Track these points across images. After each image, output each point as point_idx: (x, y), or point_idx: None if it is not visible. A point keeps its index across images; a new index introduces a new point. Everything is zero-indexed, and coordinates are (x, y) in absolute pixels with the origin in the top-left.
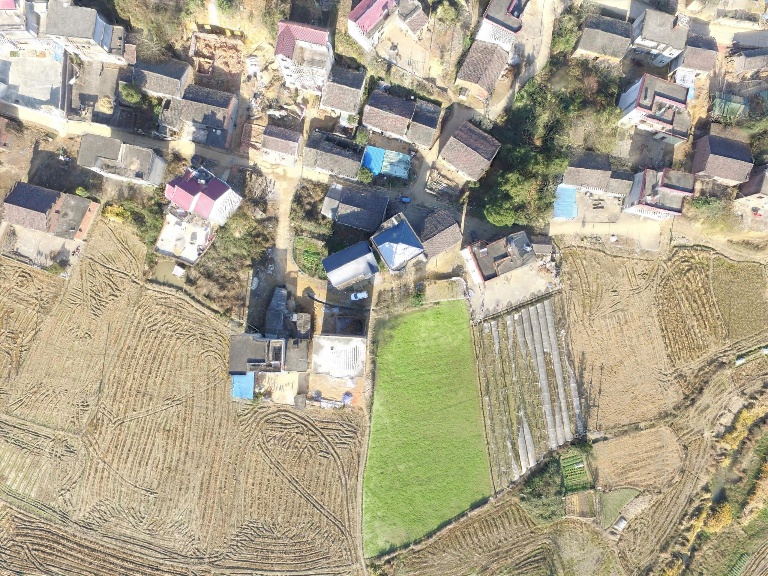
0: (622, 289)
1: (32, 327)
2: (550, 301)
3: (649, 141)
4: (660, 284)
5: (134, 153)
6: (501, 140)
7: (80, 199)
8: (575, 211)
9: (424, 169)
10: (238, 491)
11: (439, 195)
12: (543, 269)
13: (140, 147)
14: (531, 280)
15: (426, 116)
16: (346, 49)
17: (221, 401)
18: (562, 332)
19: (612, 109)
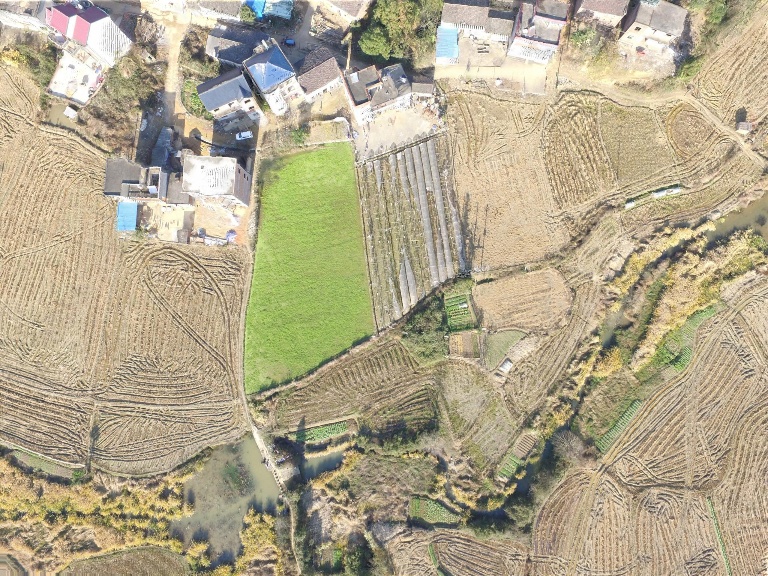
0: (508, 132)
1: None
2: (433, 141)
3: None
4: (546, 128)
5: None
6: None
7: None
8: (456, 51)
9: (309, 13)
10: (123, 326)
11: None
12: (427, 111)
13: None
14: (415, 122)
15: None
16: None
17: (108, 238)
18: (445, 171)
19: None
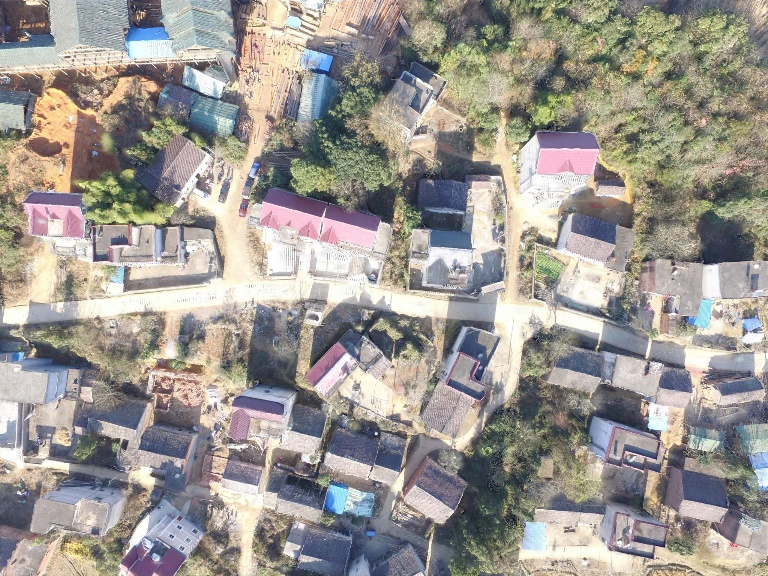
0: None
1: None
2: None
3: None
4: None
5: (90, 507)
6: (467, 477)
7: None
8: (544, 544)
9: (389, 499)
10: None
11: (404, 527)
12: None
13: (96, 502)
14: None
15: (390, 454)
16: (307, 386)
17: None
18: None
19: (583, 436)
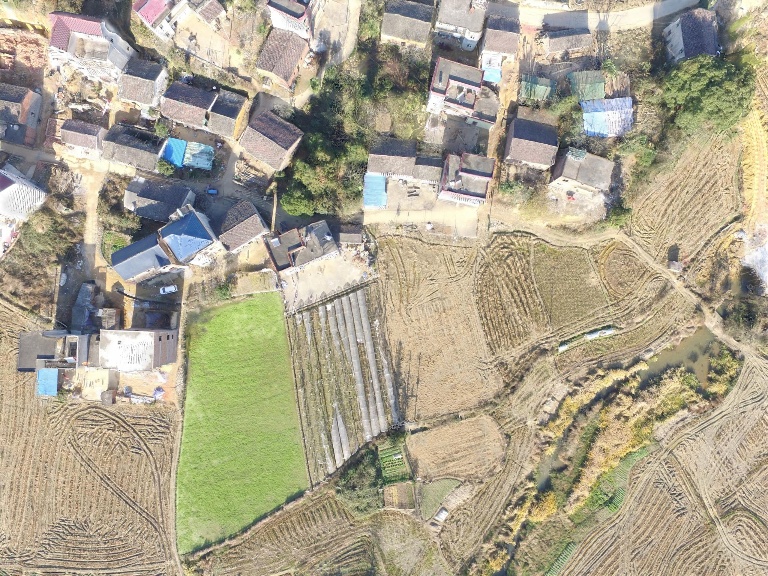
0: (440, 277)
1: None
2: (363, 291)
3: (463, 127)
4: (479, 271)
5: None
6: (305, 129)
7: None
8: (384, 199)
9: (232, 160)
10: (49, 489)
11: (247, 186)
12: (356, 259)
13: None
14: (345, 270)
15: (227, 106)
16: (145, 40)
17: (30, 399)
18: (376, 322)
19: (421, 95)
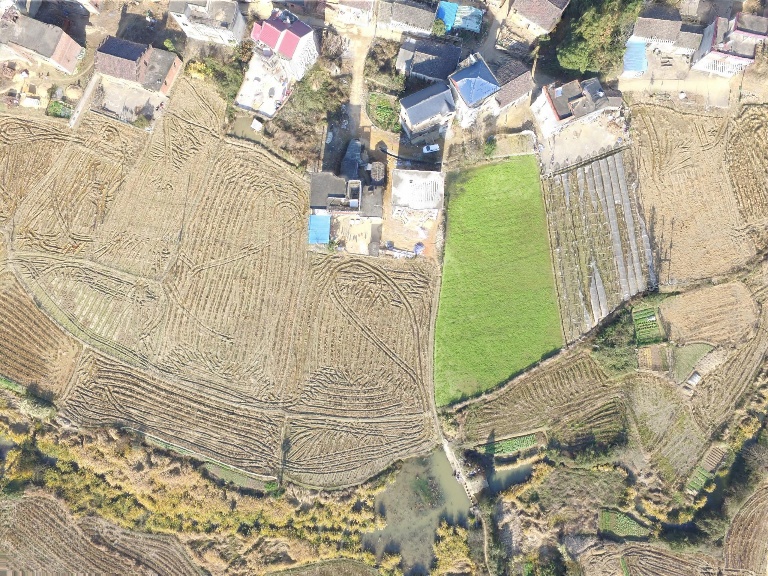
0: (692, 145)
1: (117, 178)
2: (620, 154)
3: None
4: (730, 141)
5: (219, 5)
6: None
7: (166, 53)
8: (645, 64)
9: (494, 27)
10: (312, 338)
11: (509, 51)
12: (612, 124)
13: None
14: (600, 135)
15: None
16: None
17: (296, 250)
18: (633, 185)
19: None
